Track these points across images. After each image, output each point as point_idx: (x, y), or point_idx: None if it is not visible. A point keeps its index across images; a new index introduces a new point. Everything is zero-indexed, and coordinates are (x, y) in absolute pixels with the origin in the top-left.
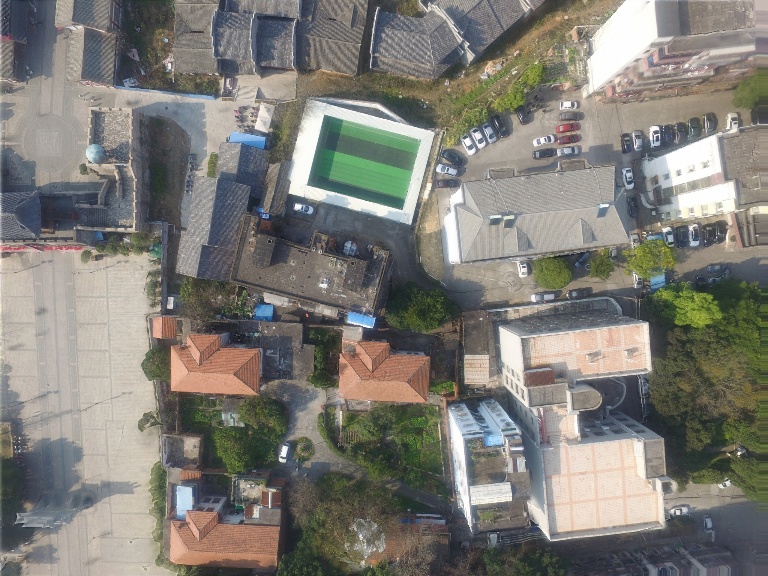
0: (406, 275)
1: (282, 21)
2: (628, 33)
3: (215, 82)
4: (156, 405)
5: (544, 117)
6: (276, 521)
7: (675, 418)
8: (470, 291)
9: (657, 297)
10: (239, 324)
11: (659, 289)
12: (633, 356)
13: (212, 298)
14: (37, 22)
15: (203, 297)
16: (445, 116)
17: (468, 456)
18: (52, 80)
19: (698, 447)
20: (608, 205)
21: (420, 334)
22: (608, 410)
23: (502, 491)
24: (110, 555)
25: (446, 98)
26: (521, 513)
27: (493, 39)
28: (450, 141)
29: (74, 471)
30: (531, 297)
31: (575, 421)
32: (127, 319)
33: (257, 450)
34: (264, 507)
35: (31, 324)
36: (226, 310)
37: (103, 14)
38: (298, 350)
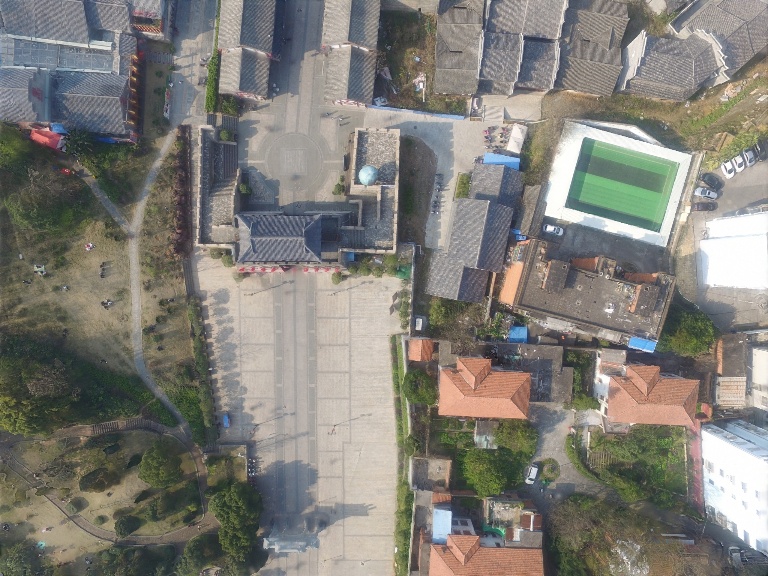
0: None
1: (541, 42)
2: None
3: (463, 102)
4: (396, 427)
5: None
6: (537, 544)
7: None
8: (721, 313)
9: None
10: (498, 347)
11: None
12: None
13: (459, 319)
14: (285, 38)
15: (450, 318)
16: None
17: None
18: (299, 98)
19: None
20: None
21: (675, 356)
22: None
23: None
24: None
25: (687, 120)
26: None
27: (744, 63)
28: (713, 165)
29: (308, 493)
30: None
31: None
32: (369, 340)
33: None
34: (525, 530)
35: (269, 345)
36: (480, 332)
37: (373, 33)
38: (557, 373)
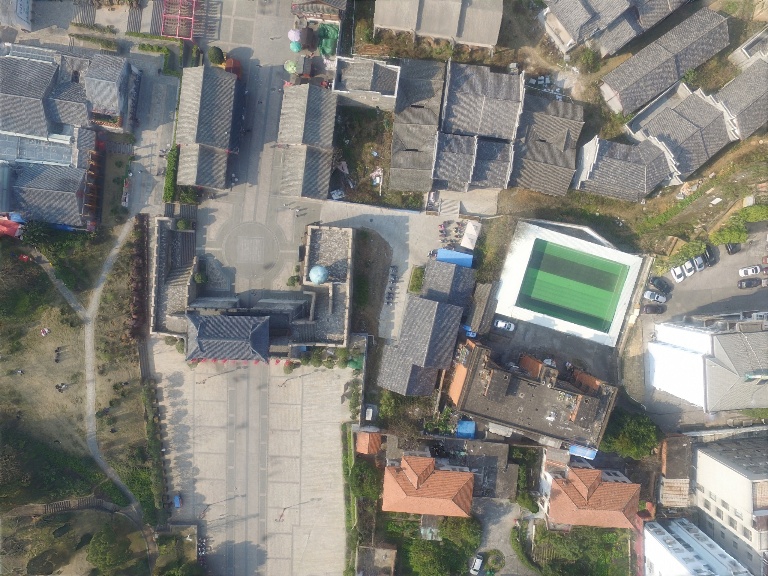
0: None
1: (496, 142)
2: None
3: (420, 196)
4: (345, 512)
5: (750, 247)
6: None
7: None
8: (668, 413)
9: None
10: (445, 442)
11: None
12: None
13: (409, 410)
14: (245, 130)
15: (400, 409)
16: None
17: None
18: (257, 188)
19: None
20: None
21: None
22: None
23: None
24: None
25: (642, 217)
26: None
27: (698, 166)
28: (662, 270)
29: (257, 573)
30: (727, 421)
31: None
32: (321, 427)
33: (449, 561)
34: None
35: (222, 428)
36: (428, 425)
37: (328, 134)
38: (502, 469)
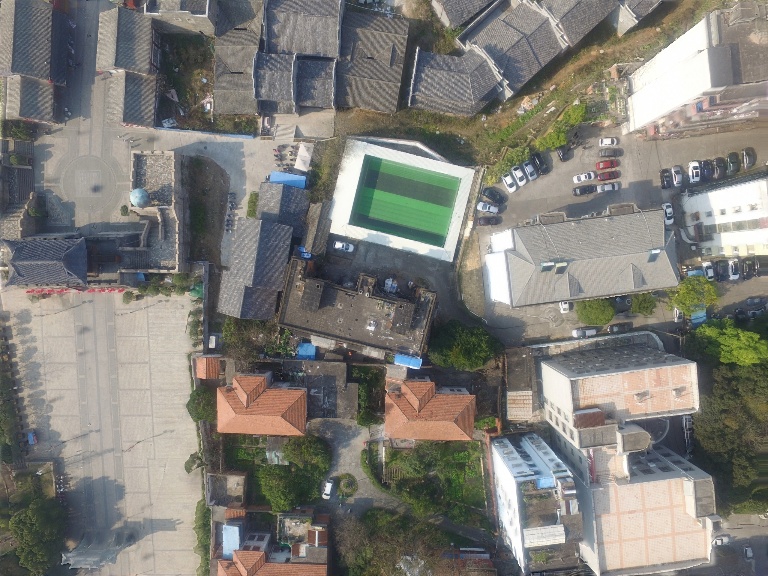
0: (447, 311)
1: (321, 61)
2: (677, 79)
3: (254, 121)
4: (198, 443)
5: (584, 154)
6: (323, 559)
7: (722, 455)
8: (511, 327)
9: (700, 333)
10: (283, 364)
11: (702, 325)
12: (681, 395)
13: (253, 336)
14: (75, 63)
15: (244, 335)
16: (484, 153)
17: (520, 498)
18: (91, 121)
19: (745, 484)
20: (660, 251)
21: (463, 371)
22: (651, 445)
23: (555, 534)
24: None
25: (483, 133)
26: (572, 553)
27: (531, 76)
28: (491, 179)
29: (116, 509)
30: (572, 332)
31: (624, 461)
32: (168, 358)
33: (300, 487)
34: (311, 546)
35: (72, 364)
36: (269, 349)
37: (144, 58)
38: (342, 389)
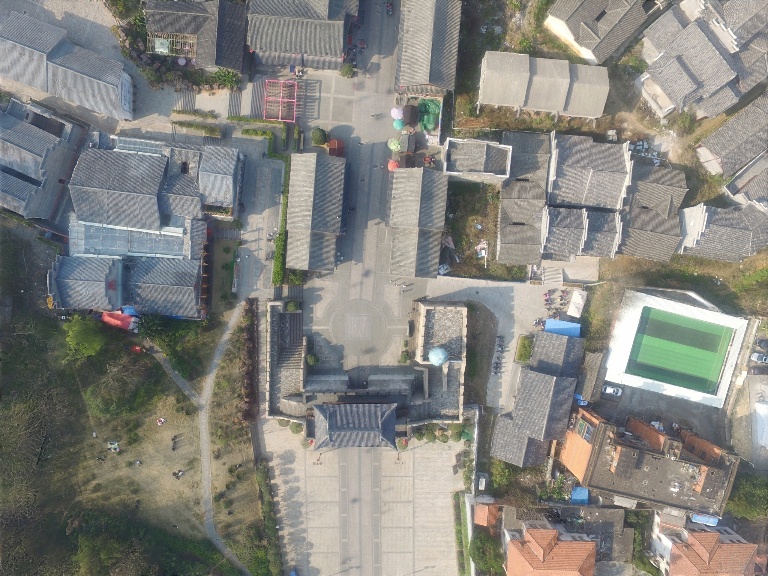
0: None
1: (601, 212)
2: None
3: (524, 266)
4: None
5: None
6: None
7: None
8: None
9: None
10: (561, 510)
11: None
12: None
13: (521, 477)
14: (349, 208)
15: (511, 476)
16: None
17: None
18: (362, 265)
19: None
20: None
21: None
22: None
23: None
24: None
25: (739, 275)
26: None
27: None
28: None
29: None
30: None
31: None
32: (433, 497)
33: None
34: None
35: (335, 503)
36: (543, 493)
37: (440, 215)
38: (618, 534)
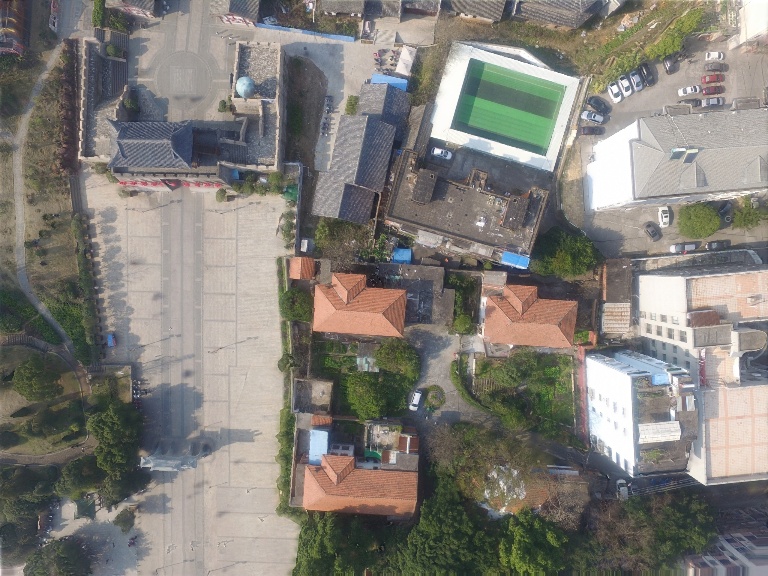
0: (544, 223)
1: None
2: None
3: (355, 24)
4: (282, 351)
5: (689, 67)
6: (413, 467)
7: None
8: (609, 240)
9: None
10: (379, 267)
11: None
12: None
13: (346, 242)
14: None
15: (336, 241)
16: None
17: (634, 395)
18: (189, 16)
19: None
20: None
21: (560, 282)
22: (749, 361)
23: (671, 430)
24: (226, 505)
25: (582, 49)
26: (683, 455)
27: None
28: (598, 87)
29: (193, 418)
30: (670, 248)
31: (735, 364)
32: (256, 262)
33: (388, 397)
34: (402, 452)
35: (156, 265)
36: (363, 253)
37: None
38: (438, 294)
